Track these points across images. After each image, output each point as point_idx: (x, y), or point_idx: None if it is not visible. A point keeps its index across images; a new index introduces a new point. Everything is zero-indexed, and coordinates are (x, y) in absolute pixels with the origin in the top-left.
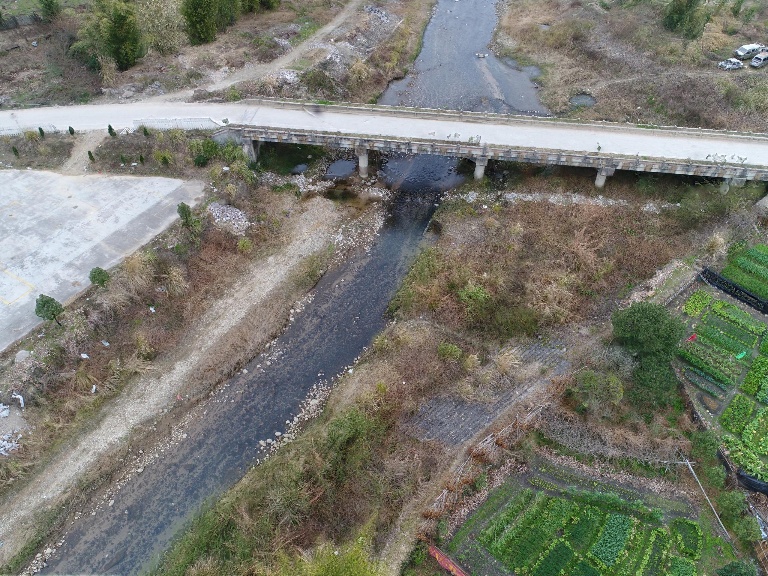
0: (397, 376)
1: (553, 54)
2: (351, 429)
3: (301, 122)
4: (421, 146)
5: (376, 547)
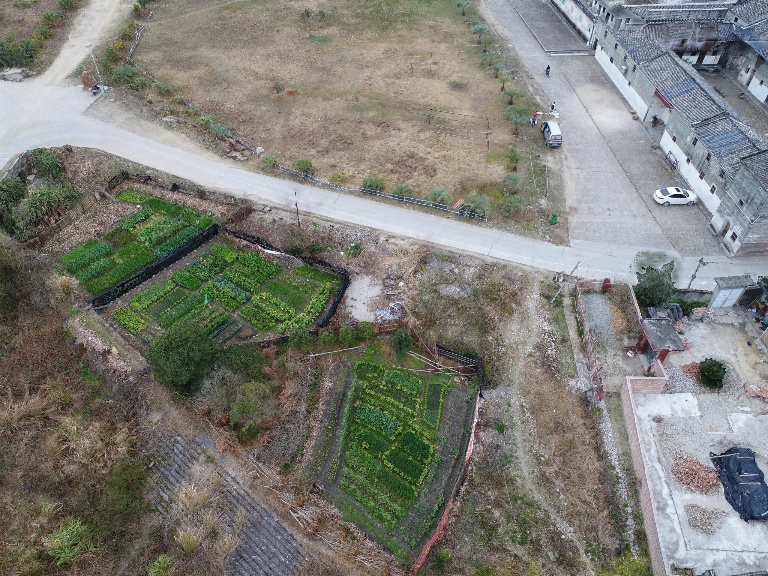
0: None
1: None
2: None
3: None
4: None
5: None
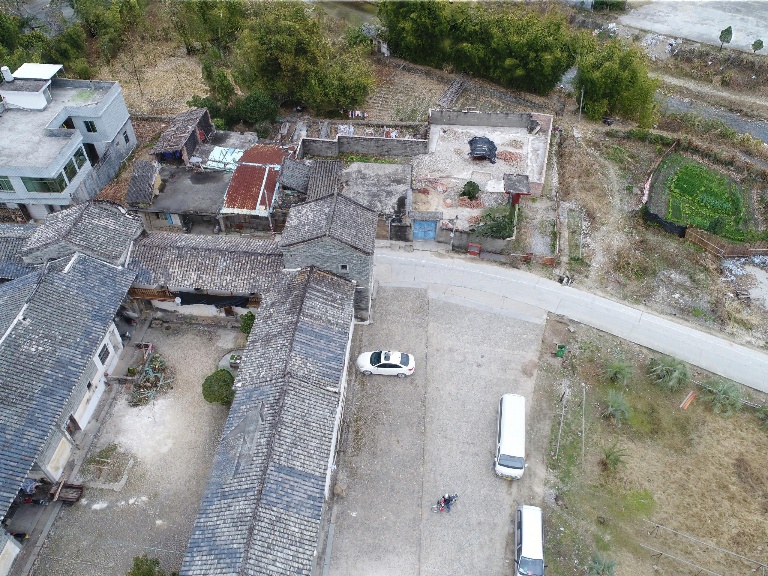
0: None
1: None
2: (723, 128)
3: None
4: None
5: None
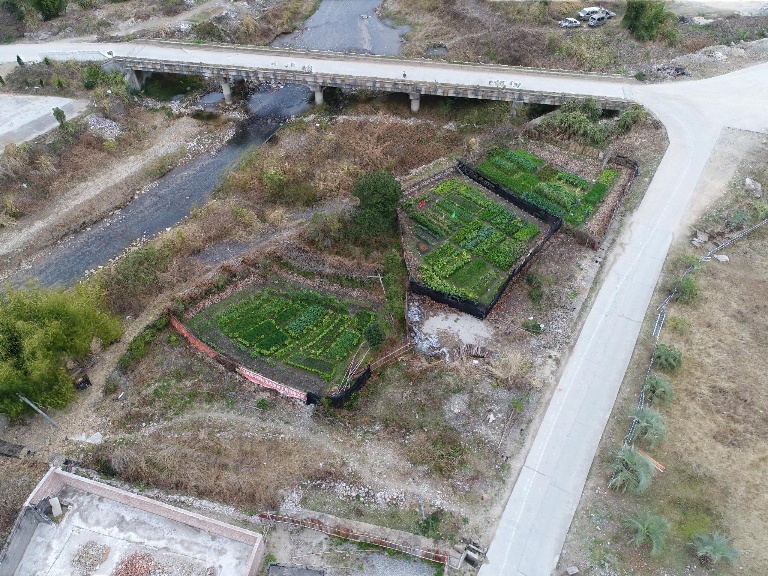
0: (199, 230)
1: (426, 16)
2: (144, 255)
3: (175, 56)
4: (265, 74)
5: (135, 319)
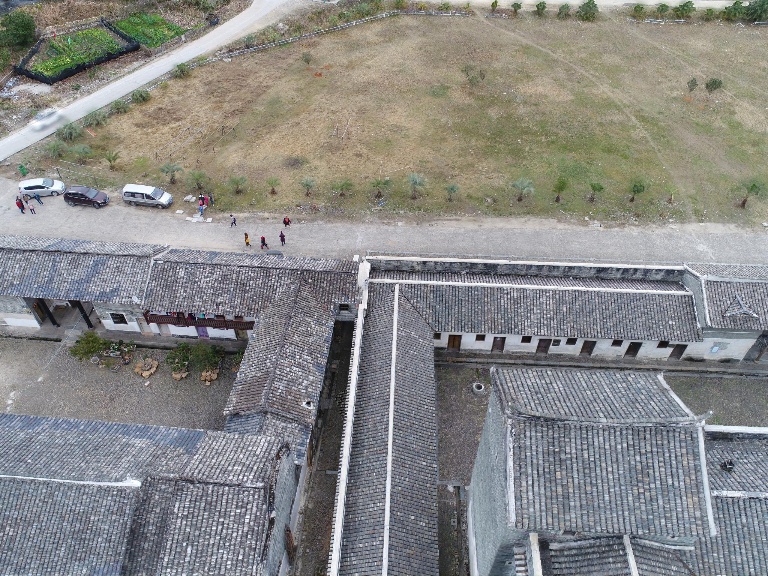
0: None
1: None
2: None
3: None
4: None
5: None
